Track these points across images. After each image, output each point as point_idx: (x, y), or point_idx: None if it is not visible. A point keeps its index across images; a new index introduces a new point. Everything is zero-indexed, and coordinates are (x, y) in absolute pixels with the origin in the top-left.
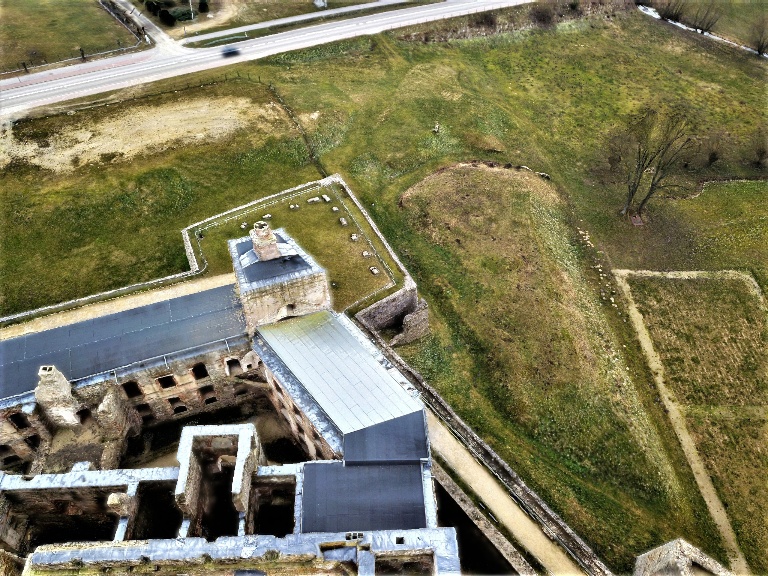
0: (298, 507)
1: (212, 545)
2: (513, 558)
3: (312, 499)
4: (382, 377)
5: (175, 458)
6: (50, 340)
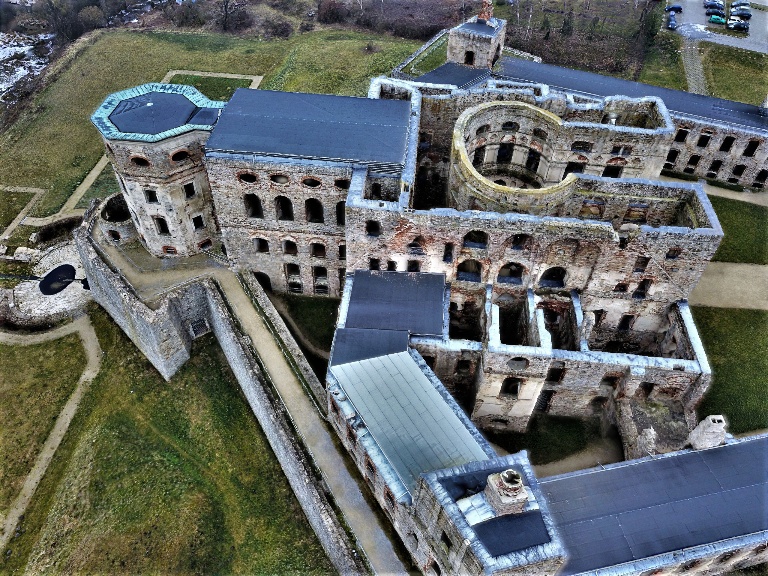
0: (447, 318)
1: (500, 216)
2: (283, 329)
3: (436, 311)
4: (363, 402)
5: (572, 466)
6: (758, 509)
